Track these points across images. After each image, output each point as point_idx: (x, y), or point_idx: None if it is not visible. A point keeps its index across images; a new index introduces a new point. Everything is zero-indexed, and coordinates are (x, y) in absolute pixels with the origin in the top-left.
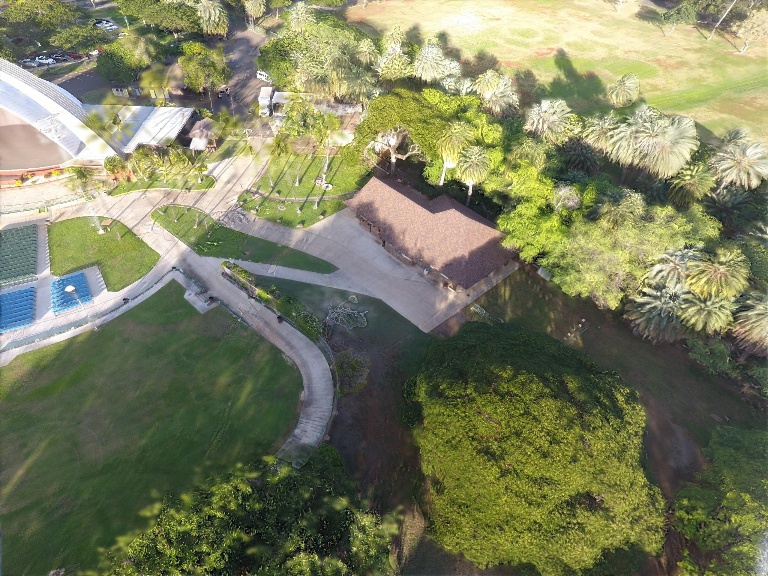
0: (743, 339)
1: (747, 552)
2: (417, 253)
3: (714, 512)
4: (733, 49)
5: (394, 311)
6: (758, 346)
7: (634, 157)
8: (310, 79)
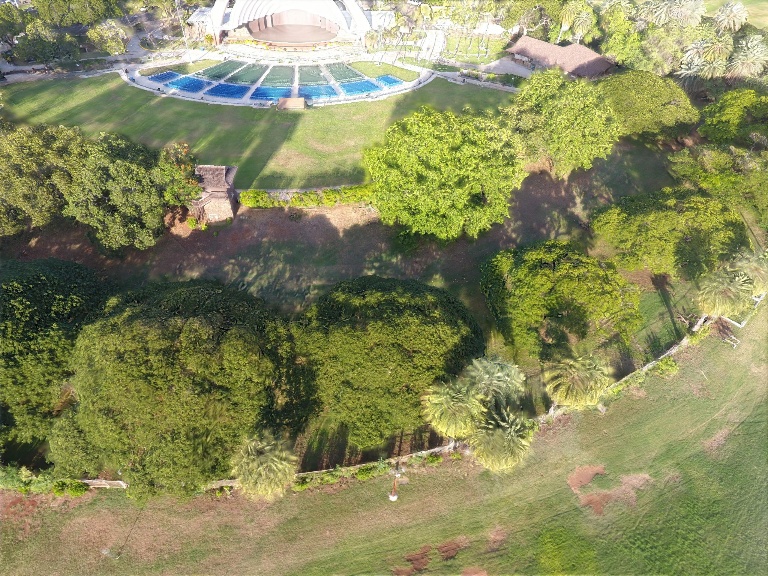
0: (730, 78)
1: (730, 103)
2: (558, 66)
3: None
4: None
5: None
6: (737, 78)
7: None
8: None
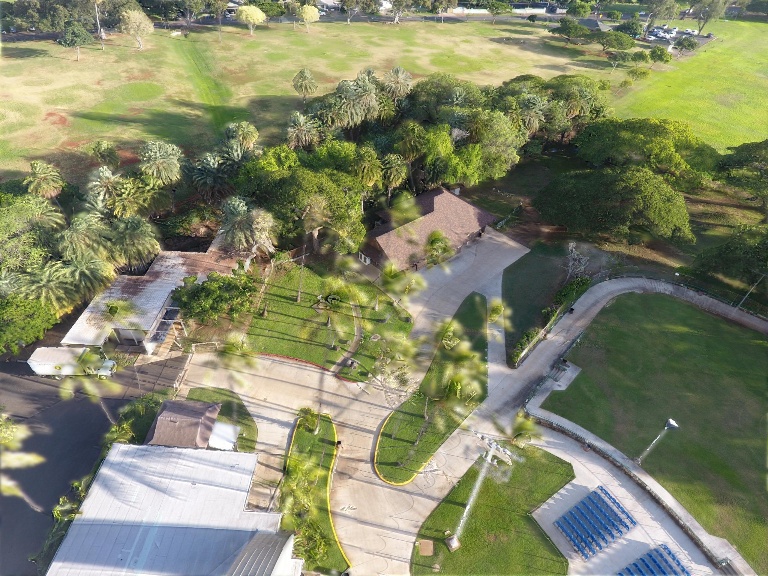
0: None
1: (667, 154)
2: (464, 235)
3: (647, 160)
4: (131, 48)
5: (515, 263)
6: None
7: (362, 115)
8: (73, 286)
